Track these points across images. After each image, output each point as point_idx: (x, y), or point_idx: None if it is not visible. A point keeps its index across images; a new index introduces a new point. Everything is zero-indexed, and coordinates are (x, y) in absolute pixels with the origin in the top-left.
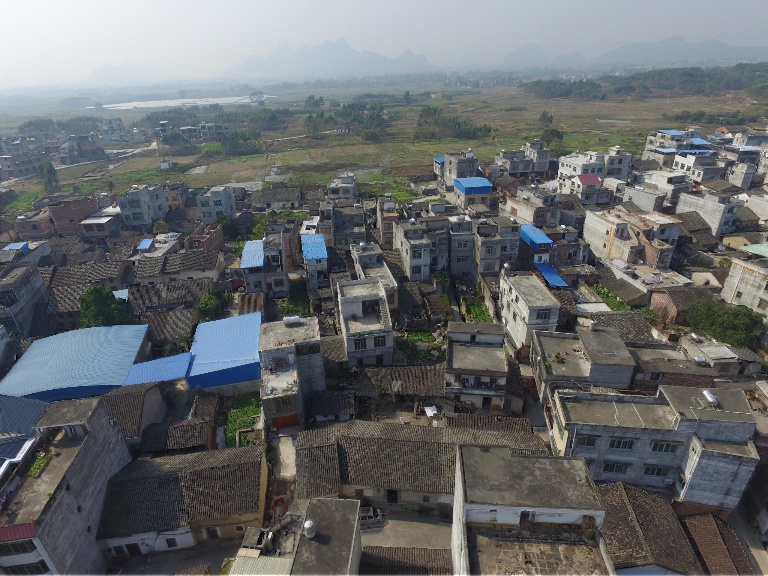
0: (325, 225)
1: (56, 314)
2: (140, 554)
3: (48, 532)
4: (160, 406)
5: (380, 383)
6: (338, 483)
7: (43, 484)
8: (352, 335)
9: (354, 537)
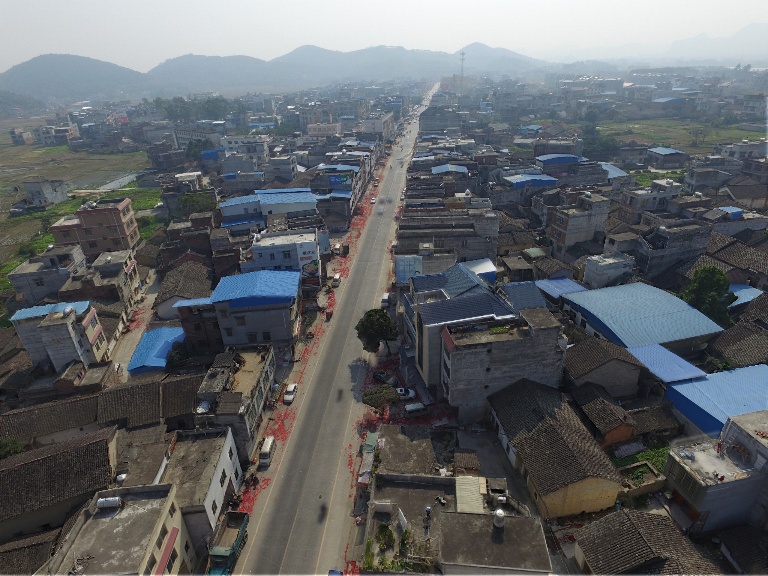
0: None
1: (681, 275)
2: (498, 435)
3: (459, 359)
4: (629, 385)
5: None
6: (609, 574)
7: (486, 338)
8: None
9: (505, 568)
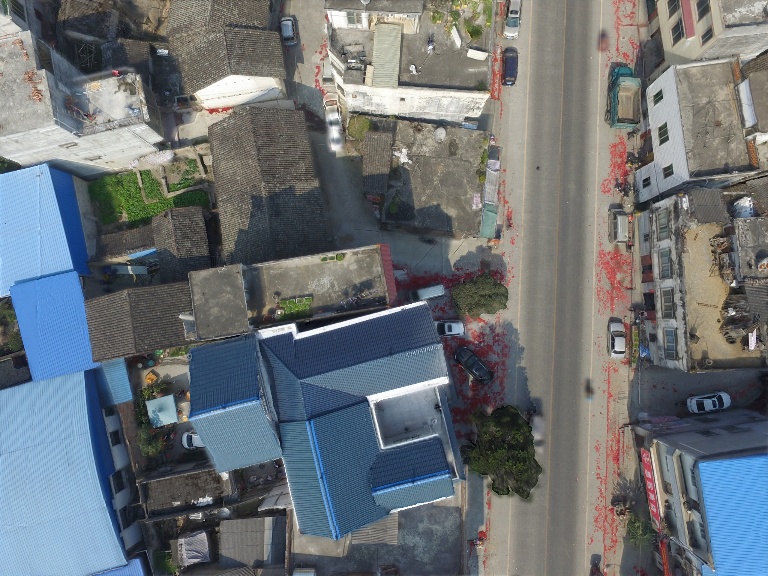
0: None
1: None
2: None
3: None
4: None
5: (95, 3)
6: (269, 34)
7: (322, 282)
8: (2, 5)
9: None
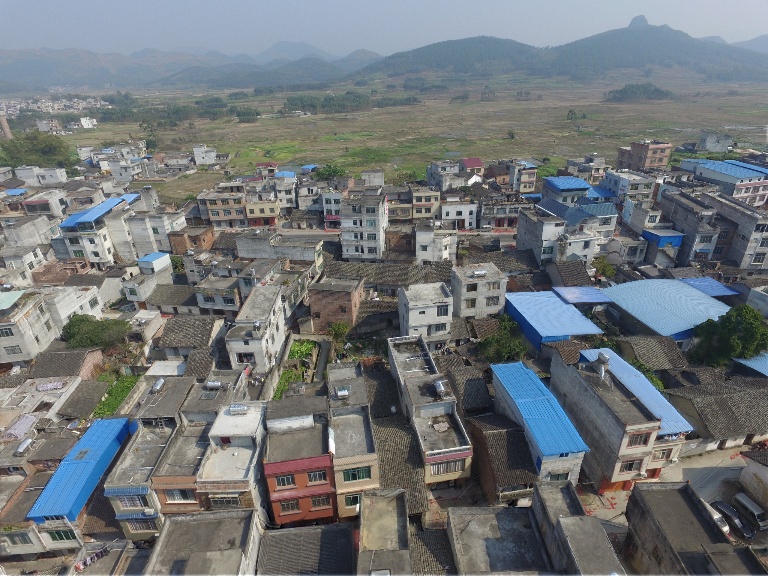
0: (553, 485)
1: None
2: None
3: None
4: None
5: None
6: None
7: None
8: None
9: None
